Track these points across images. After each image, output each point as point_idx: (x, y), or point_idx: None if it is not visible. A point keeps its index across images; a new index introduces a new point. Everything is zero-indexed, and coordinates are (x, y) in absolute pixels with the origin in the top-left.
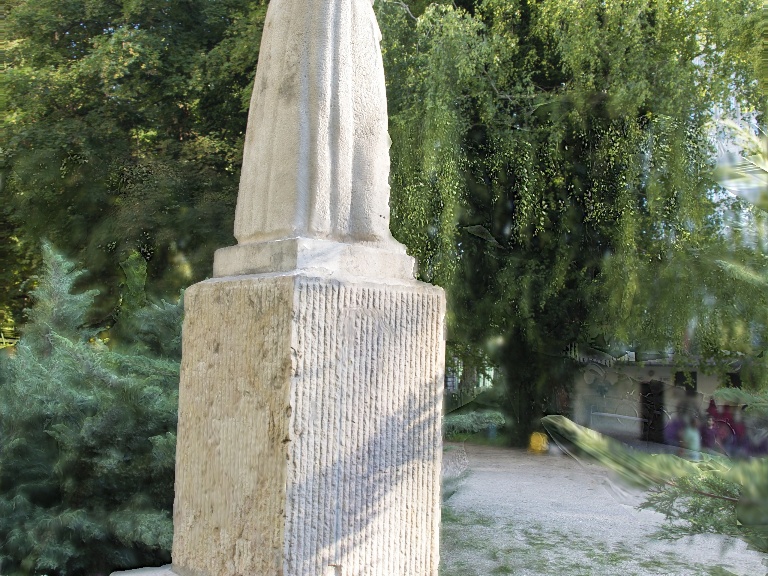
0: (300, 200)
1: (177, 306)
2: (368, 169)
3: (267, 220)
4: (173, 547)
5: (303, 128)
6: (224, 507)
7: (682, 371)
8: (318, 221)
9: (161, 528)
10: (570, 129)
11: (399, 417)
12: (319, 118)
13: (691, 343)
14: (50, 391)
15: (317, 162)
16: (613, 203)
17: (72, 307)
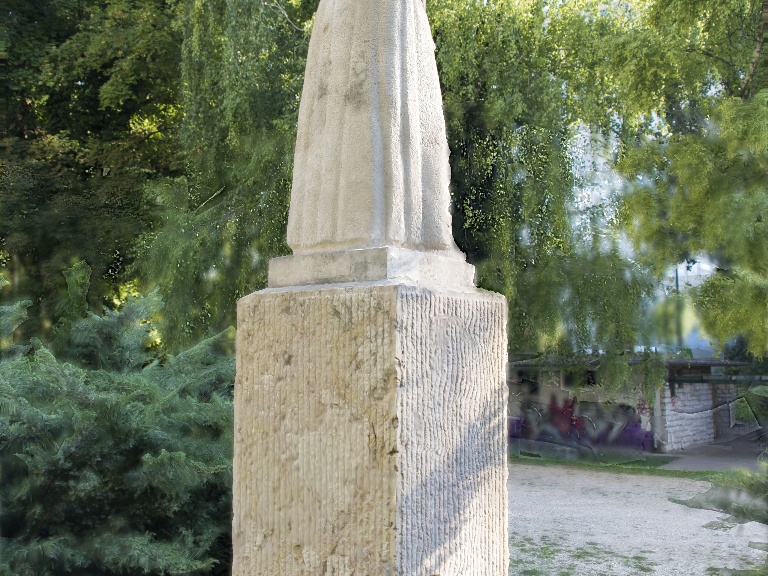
0: (376, 208)
1: (122, 317)
2: (436, 178)
3: (338, 228)
4: (234, 569)
5: (375, 136)
6: (308, 524)
7: (547, 370)
8: (394, 230)
9: (156, 551)
10: (453, 138)
11: (477, 424)
12: (391, 126)
13: (568, 343)
14: (18, 411)
15: (391, 170)
16: (491, 210)
17: (5, 319)
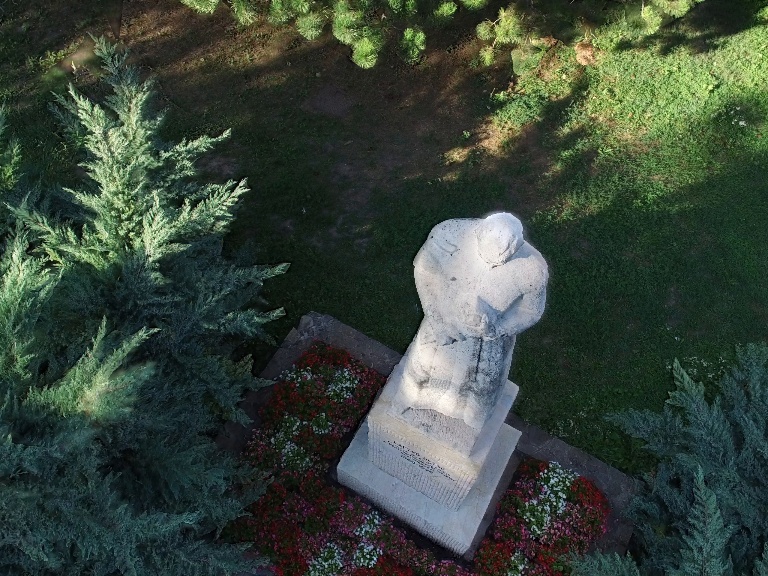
0: None
1: None
2: None
3: None
4: None
5: None
6: None
7: None
8: None
9: None
10: None
11: None
12: None
13: None
14: None
15: None
16: None
17: None
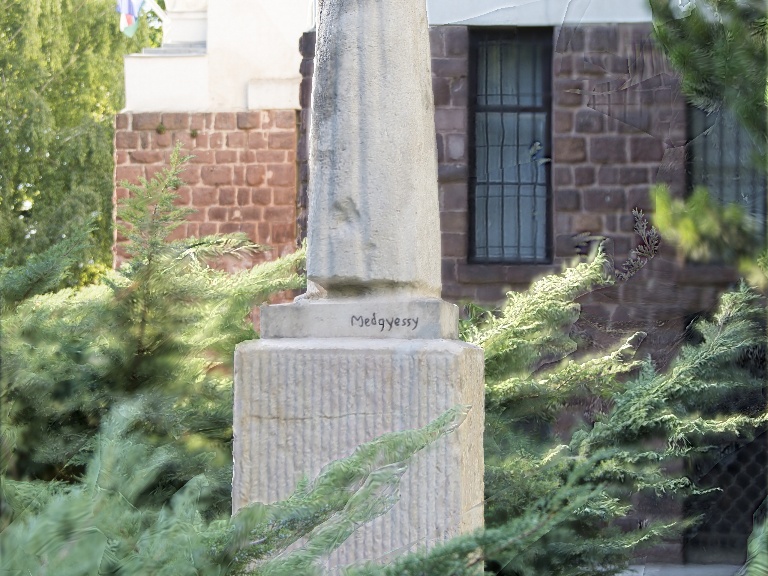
0: None
1: None
2: None
3: None
4: None
5: None
6: None
7: None
8: None
9: None
10: None
11: None
12: None
13: None
14: None
15: None
16: None
17: None
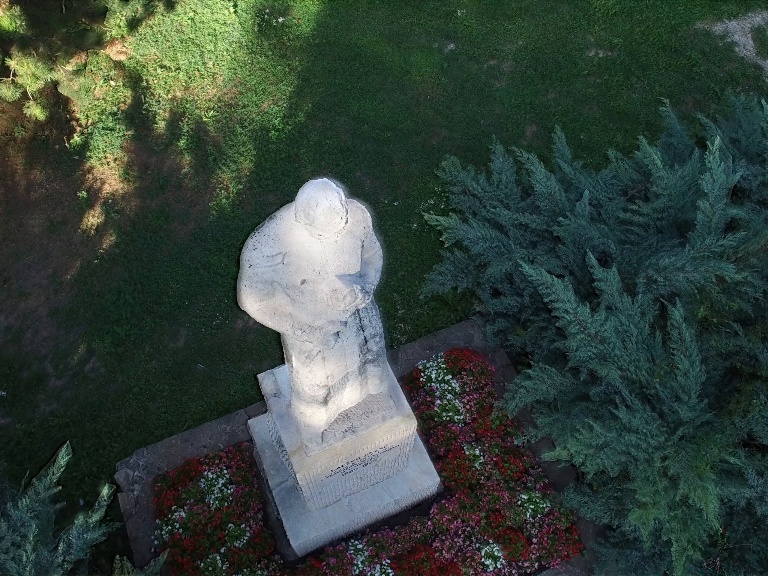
0: None
1: None
2: None
3: None
4: None
5: None
6: None
7: None
8: None
9: None
10: None
11: None
12: None
13: None
14: None
15: None
16: None
17: None
